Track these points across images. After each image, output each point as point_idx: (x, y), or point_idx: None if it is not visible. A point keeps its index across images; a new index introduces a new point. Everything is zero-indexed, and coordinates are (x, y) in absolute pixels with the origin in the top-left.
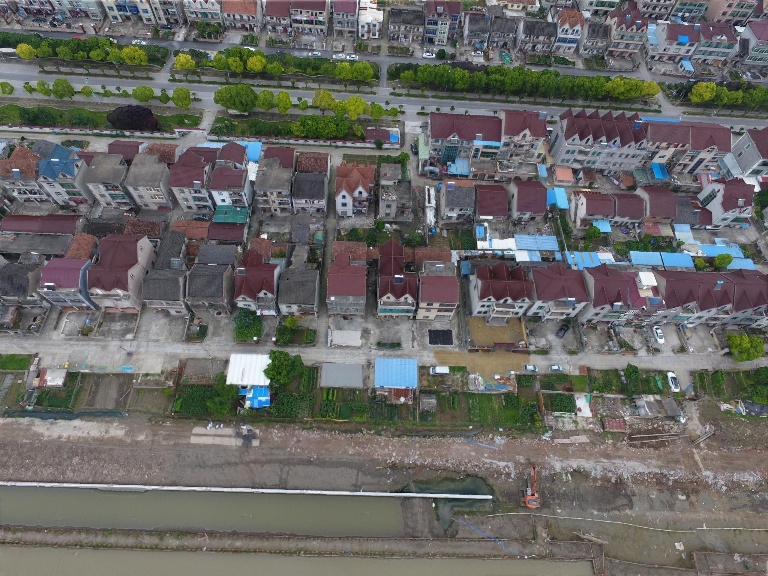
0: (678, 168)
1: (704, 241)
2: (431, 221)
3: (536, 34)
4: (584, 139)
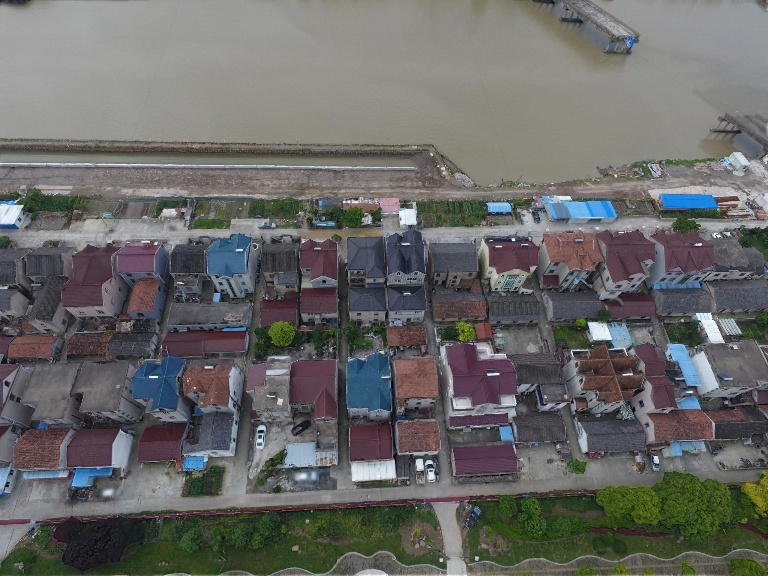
0: None
1: None
2: None
3: None
4: None
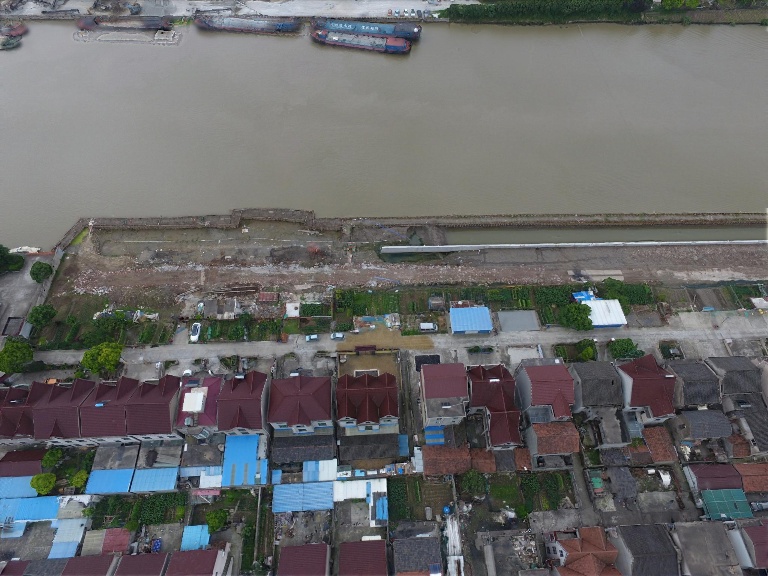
0: None
1: (36, 538)
2: (452, 525)
3: None
4: None
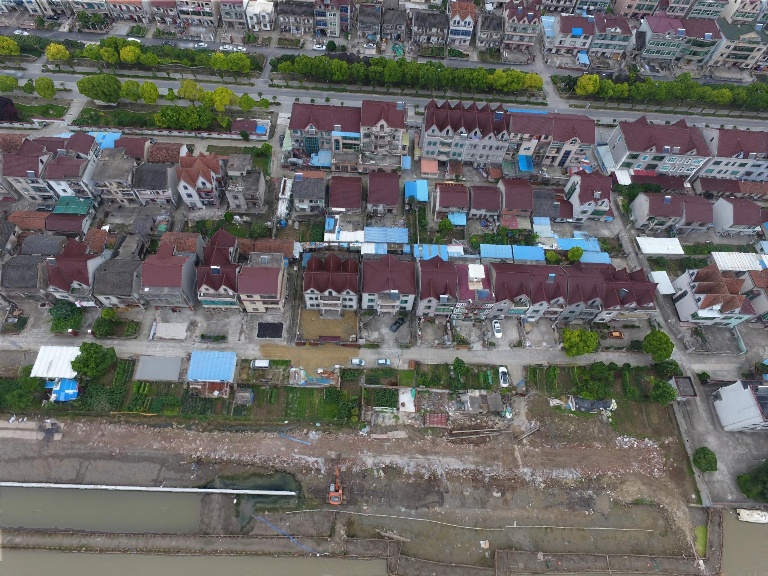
0: (547, 161)
1: (565, 234)
2: (281, 213)
3: (427, 26)
4: (443, 130)
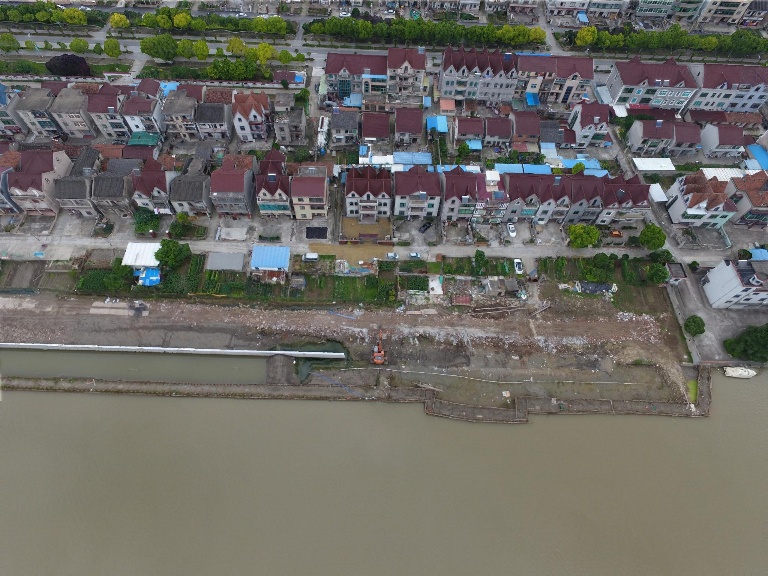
0: (552, 98)
1: (569, 158)
2: (321, 143)
3: None
4: (460, 70)
